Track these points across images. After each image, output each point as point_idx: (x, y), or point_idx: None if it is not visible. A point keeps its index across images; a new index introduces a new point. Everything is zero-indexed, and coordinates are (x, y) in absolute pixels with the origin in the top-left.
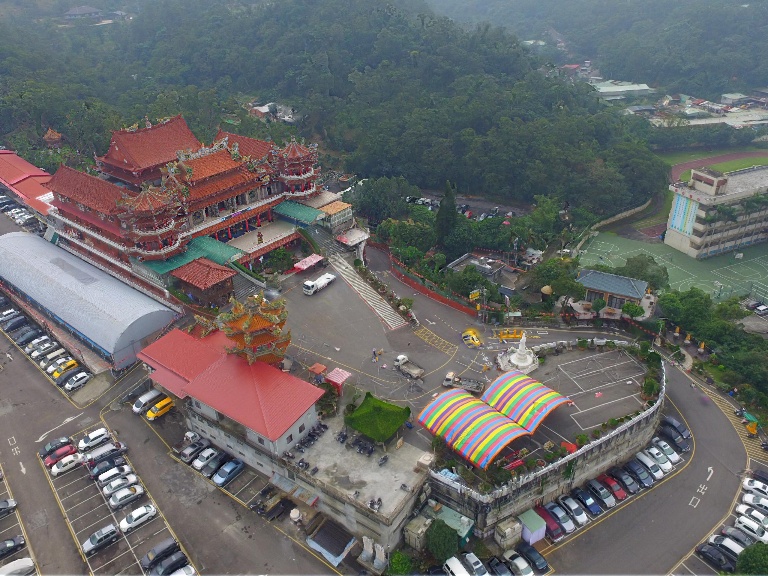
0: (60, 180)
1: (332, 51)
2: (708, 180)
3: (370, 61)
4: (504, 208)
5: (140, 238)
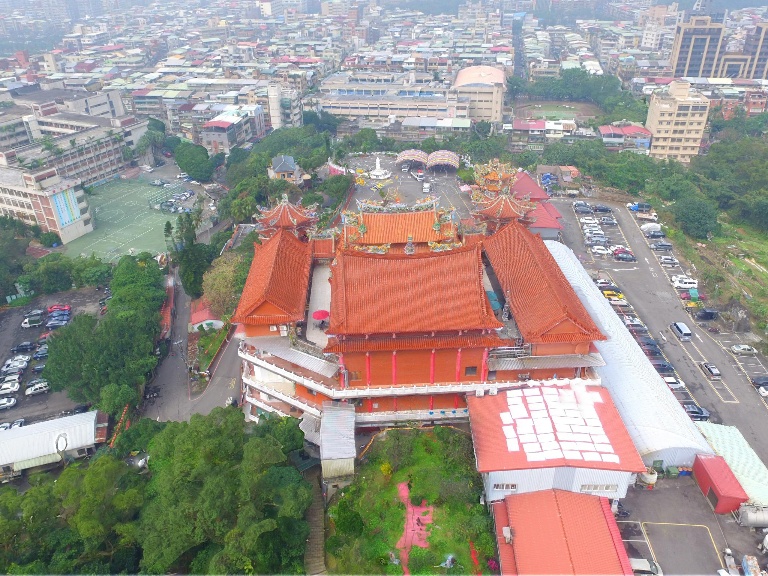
0: None
1: None
2: (50, 173)
3: None
4: (8, 327)
5: None
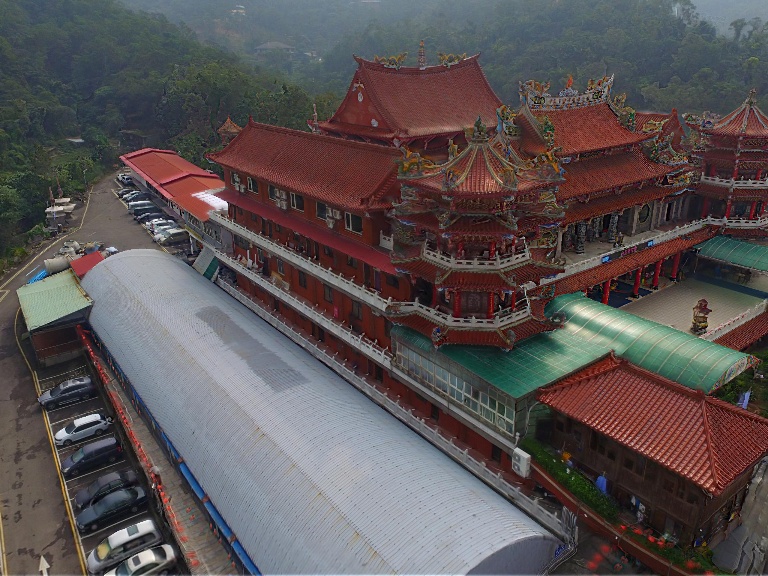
0: (243, 148)
1: (611, 60)
2: None
3: (660, 79)
4: None
5: (448, 276)
